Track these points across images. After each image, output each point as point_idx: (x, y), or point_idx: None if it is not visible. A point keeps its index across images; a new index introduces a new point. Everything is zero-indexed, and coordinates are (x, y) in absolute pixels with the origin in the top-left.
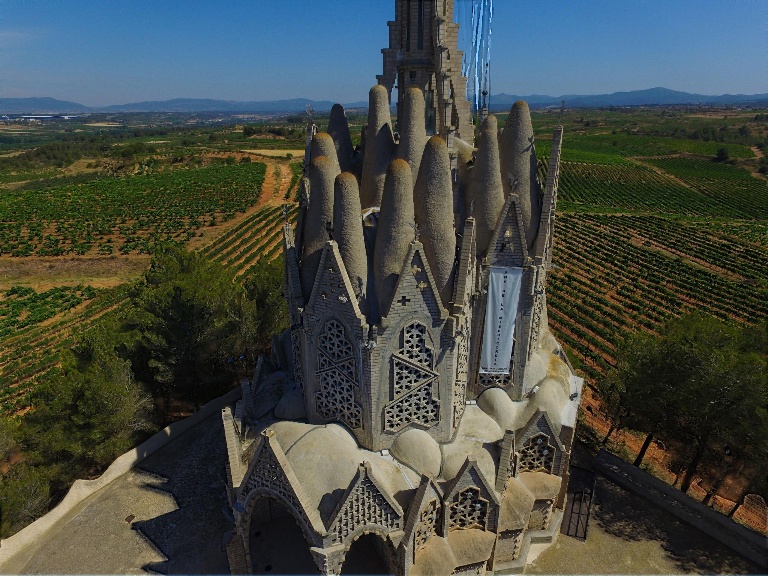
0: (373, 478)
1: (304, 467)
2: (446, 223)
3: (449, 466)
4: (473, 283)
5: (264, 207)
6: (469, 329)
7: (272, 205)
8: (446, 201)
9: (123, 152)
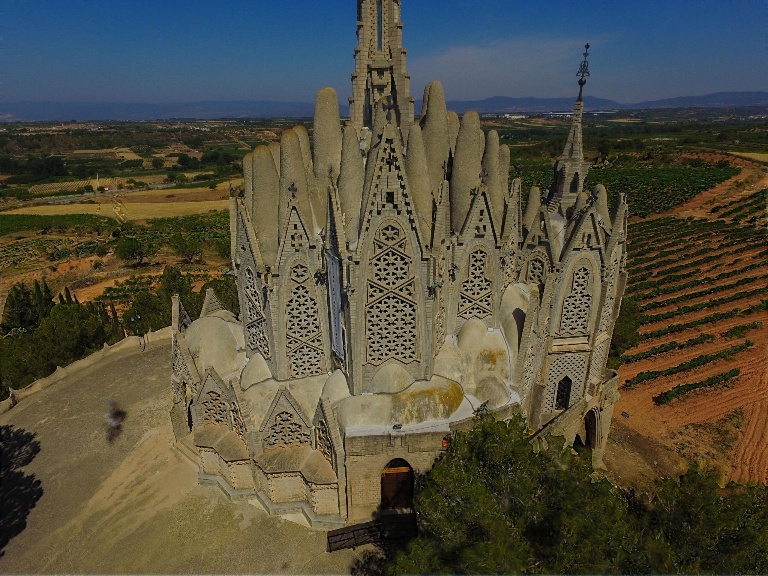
0: (179, 344)
1: (191, 329)
2: (283, 200)
3: (250, 387)
4: (319, 261)
5: (669, 216)
6: (324, 304)
7: (682, 216)
8: (285, 182)
9: (591, 146)
